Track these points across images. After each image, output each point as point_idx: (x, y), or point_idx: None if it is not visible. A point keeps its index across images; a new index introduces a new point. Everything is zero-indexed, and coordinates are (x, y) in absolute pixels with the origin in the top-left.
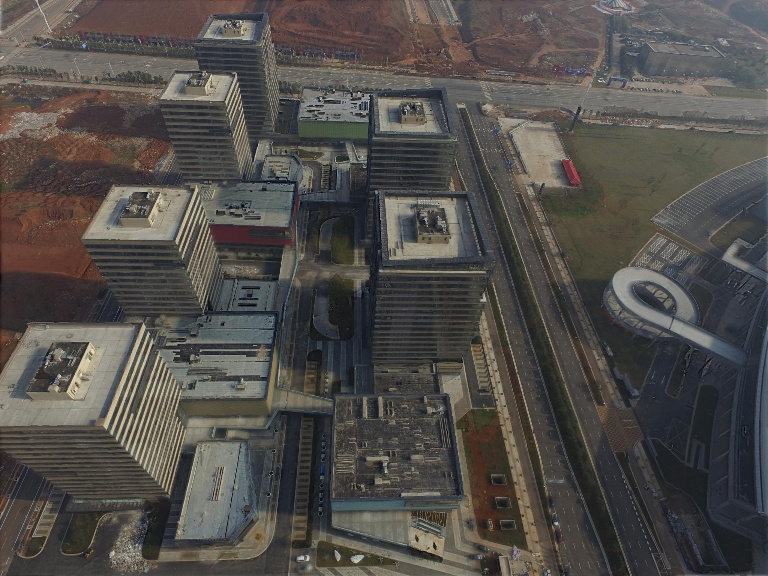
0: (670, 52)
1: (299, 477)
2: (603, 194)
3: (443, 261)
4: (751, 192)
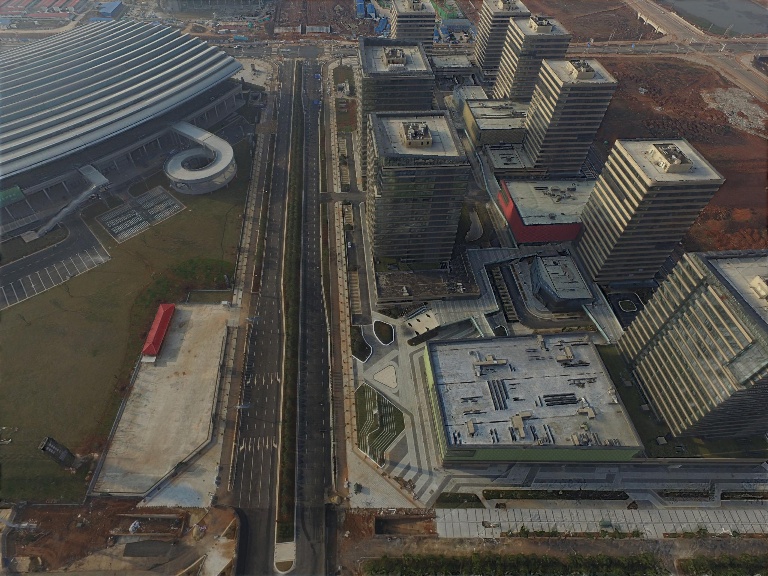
0: None
1: None
2: None
3: (388, 39)
4: None
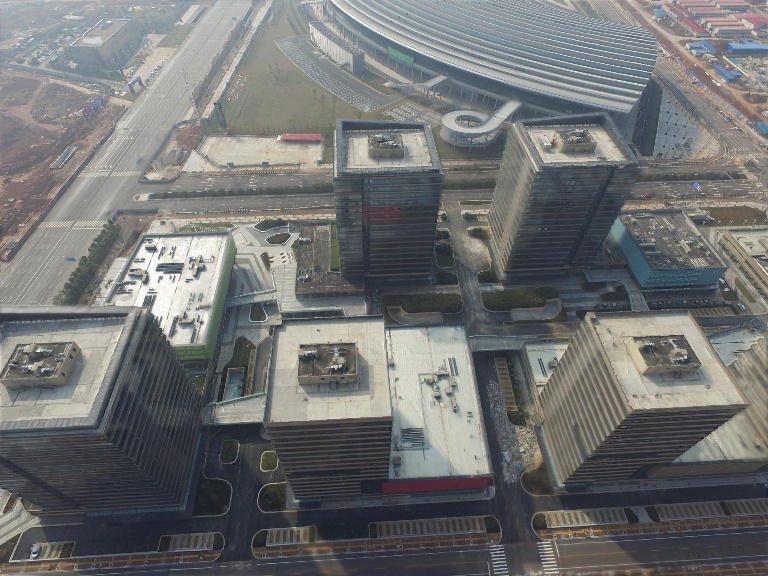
0: (105, 40)
1: None
2: (333, 128)
3: None
4: (328, 67)
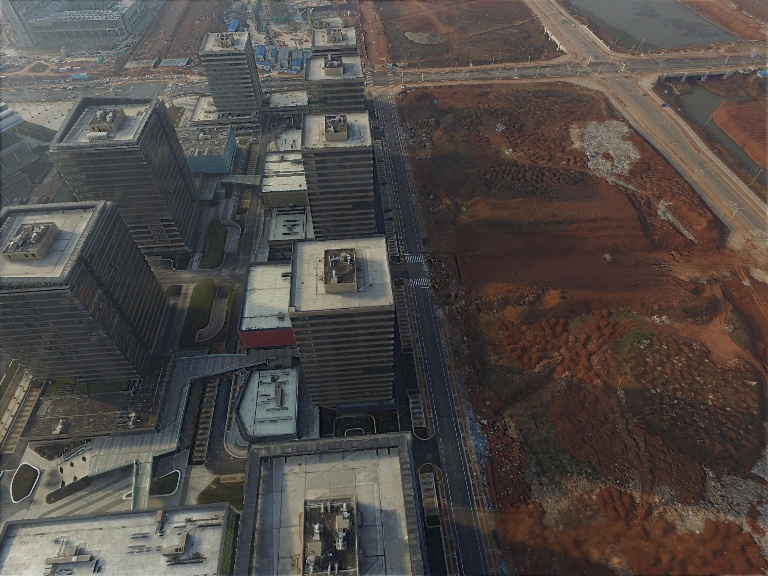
0: None
1: (255, 161)
2: None
3: None
4: None
